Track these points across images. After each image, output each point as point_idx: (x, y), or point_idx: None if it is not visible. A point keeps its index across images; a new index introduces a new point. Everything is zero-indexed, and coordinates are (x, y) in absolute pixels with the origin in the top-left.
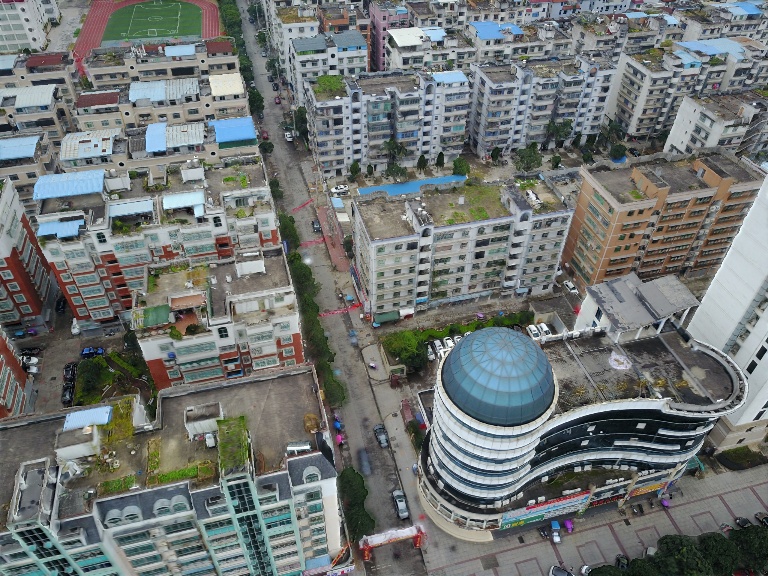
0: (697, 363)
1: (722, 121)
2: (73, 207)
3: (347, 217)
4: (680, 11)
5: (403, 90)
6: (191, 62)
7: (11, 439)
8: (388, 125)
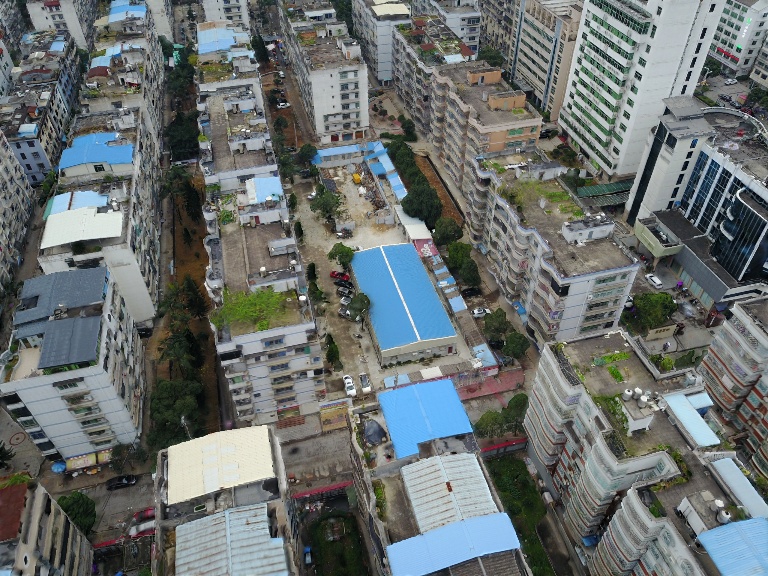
0: (712, 120)
1: (364, 65)
2: None
3: (430, 369)
4: (102, 41)
5: (273, 238)
6: None
7: None
8: None
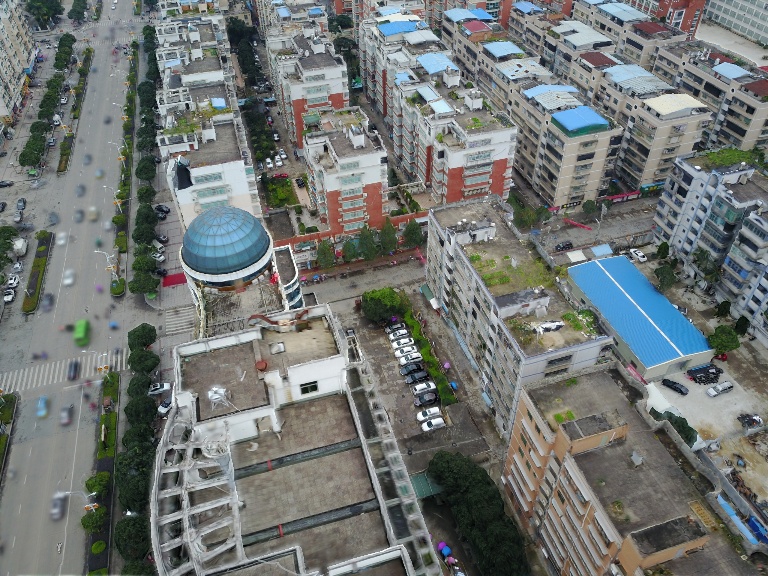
0: None
1: None
2: (424, 76)
3: (579, 259)
4: None
5: None
6: (724, 85)
7: (220, 94)
8: (722, 237)
